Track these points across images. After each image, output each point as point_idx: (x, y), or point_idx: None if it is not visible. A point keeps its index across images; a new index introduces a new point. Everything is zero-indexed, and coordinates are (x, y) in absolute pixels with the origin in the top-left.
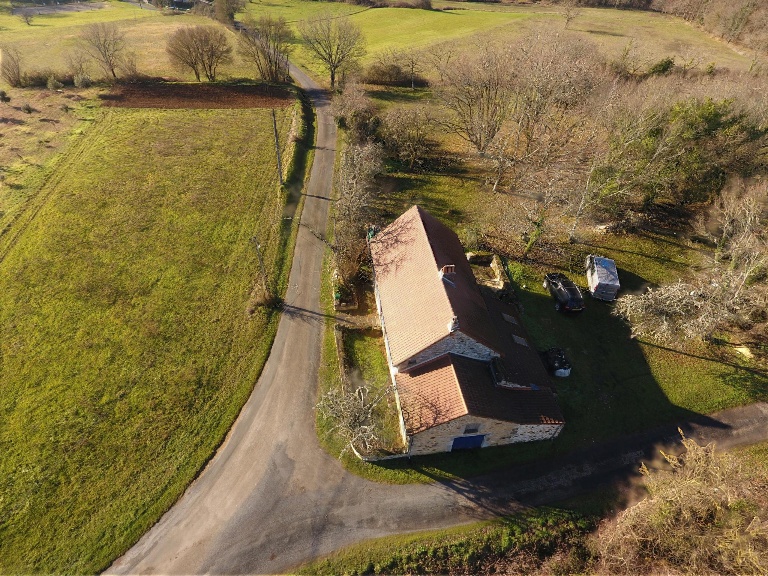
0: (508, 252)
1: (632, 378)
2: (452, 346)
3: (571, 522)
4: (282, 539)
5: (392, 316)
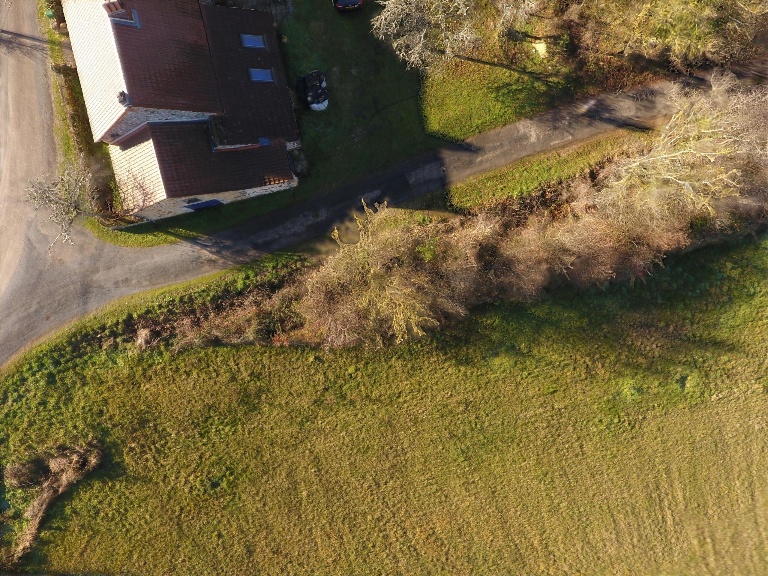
0: None
1: (394, 105)
2: (145, 117)
3: (299, 263)
4: (52, 304)
5: (82, 71)
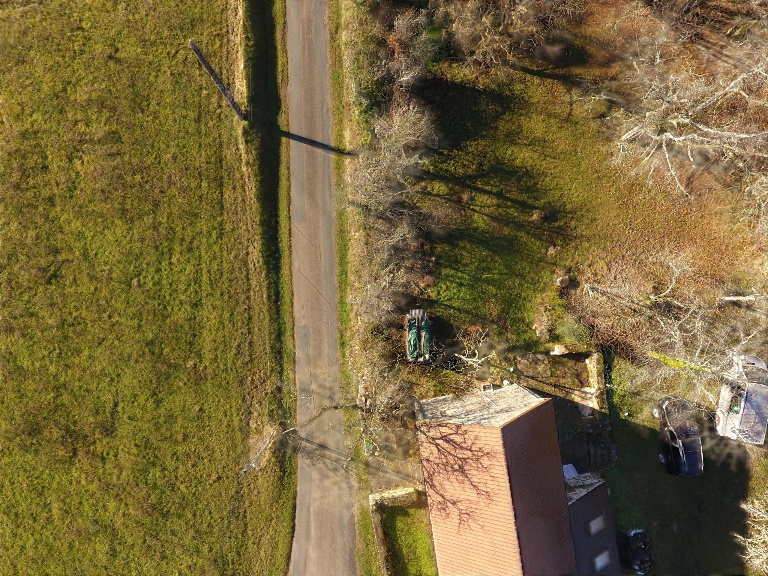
0: (618, 338)
1: (718, 572)
2: None
3: None
4: None
5: None
